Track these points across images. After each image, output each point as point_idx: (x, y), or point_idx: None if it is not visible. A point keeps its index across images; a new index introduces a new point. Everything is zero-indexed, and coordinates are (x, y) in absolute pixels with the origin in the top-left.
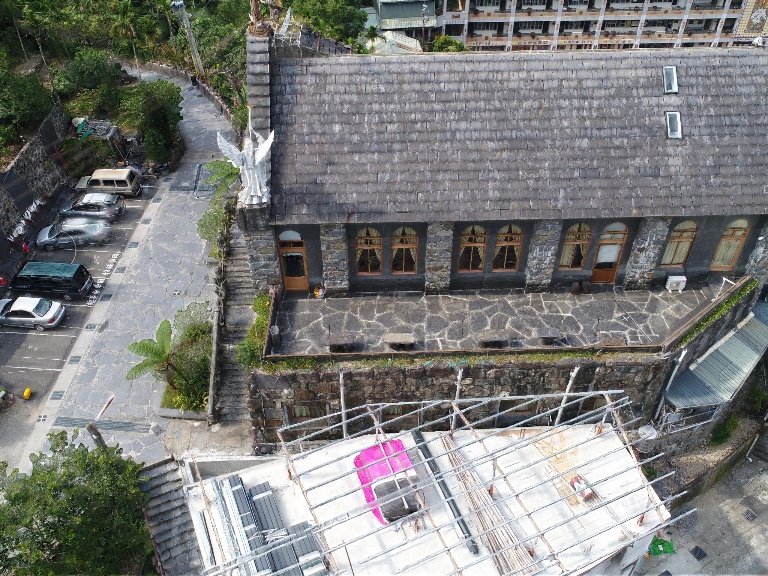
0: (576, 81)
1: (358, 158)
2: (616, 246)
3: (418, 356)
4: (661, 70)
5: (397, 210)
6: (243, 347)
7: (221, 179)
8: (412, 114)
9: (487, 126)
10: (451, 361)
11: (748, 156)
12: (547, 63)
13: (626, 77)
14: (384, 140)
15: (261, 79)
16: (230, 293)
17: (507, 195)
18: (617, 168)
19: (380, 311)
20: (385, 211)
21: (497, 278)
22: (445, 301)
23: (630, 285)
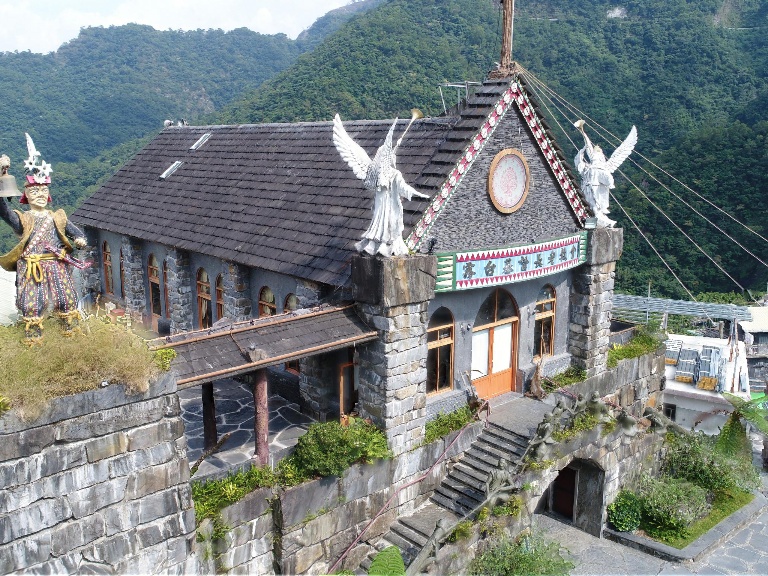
0: None
1: None
2: None
3: None
4: None
5: None
6: (660, 321)
7: None
8: None
9: None
10: None
11: None
12: None
13: None
14: None
15: None
16: None
17: None
18: None
19: None
20: None
21: None
22: None
23: None
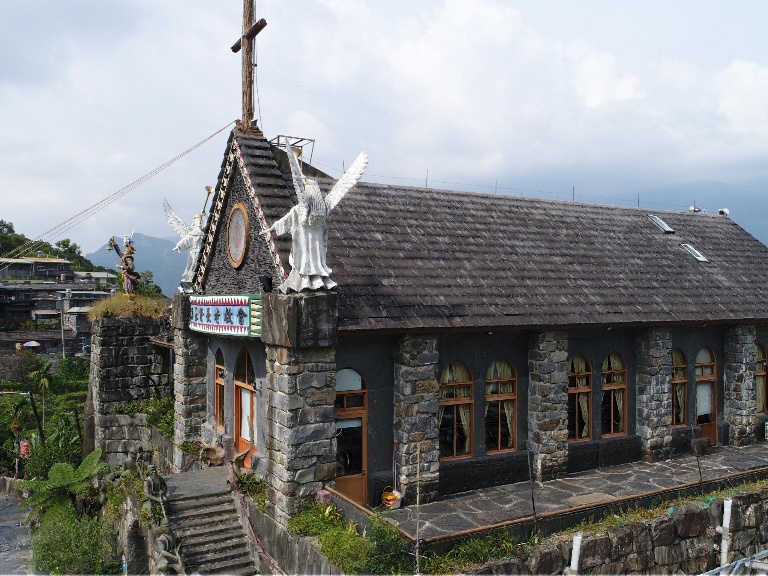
0: (590, 219)
1: (422, 263)
2: (706, 388)
3: (651, 503)
4: (648, 218)
5: (505, 313)
6: (375, 526)
7: (52, 498)
8: (457, 230)
9: (541, 244)
10: (696, 502)
11: (766, 276)
12: (555, 205)
13: (626, 220)
14: (442, 249)
15: (269, 171)
16: (189, 574)
17: (610, 299)
18: (683, 281)
19: (505, 502)
20: (491, 313)
21: (612, 445)
22: (573, 482)
23: (741, 438)
